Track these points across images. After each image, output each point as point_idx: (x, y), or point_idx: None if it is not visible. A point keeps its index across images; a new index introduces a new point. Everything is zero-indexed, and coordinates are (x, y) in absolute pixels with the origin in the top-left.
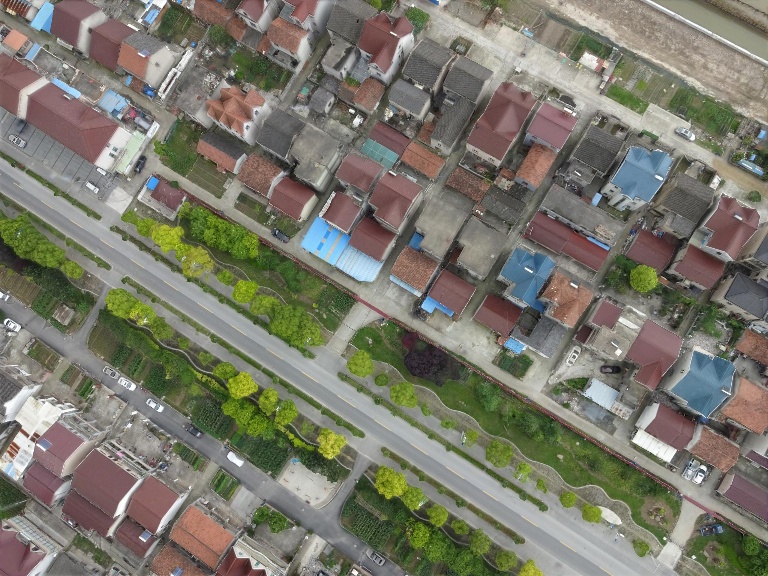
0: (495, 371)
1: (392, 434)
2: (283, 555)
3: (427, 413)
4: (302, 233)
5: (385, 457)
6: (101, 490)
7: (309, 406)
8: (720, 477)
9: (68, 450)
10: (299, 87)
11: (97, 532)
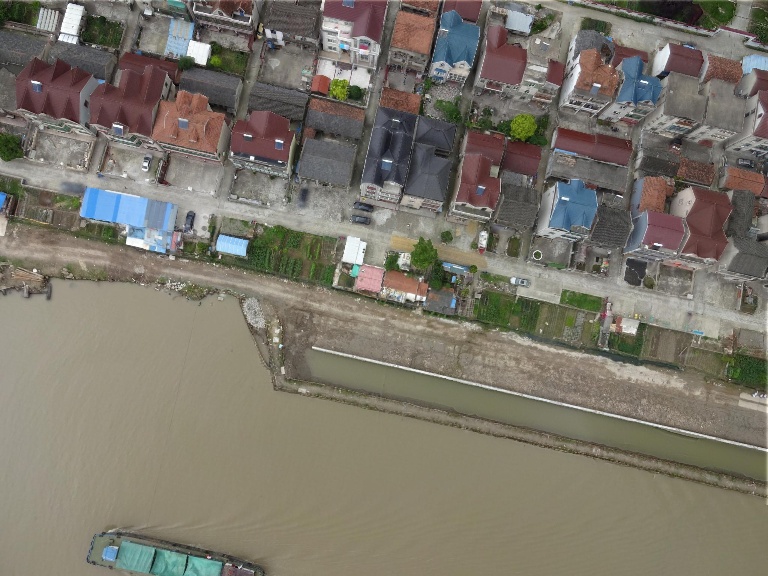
0: (606, 18)
1: None
2: None
3: None
4: None
5: None
6: None
7: None
8: None
9: None
10: None
11: None
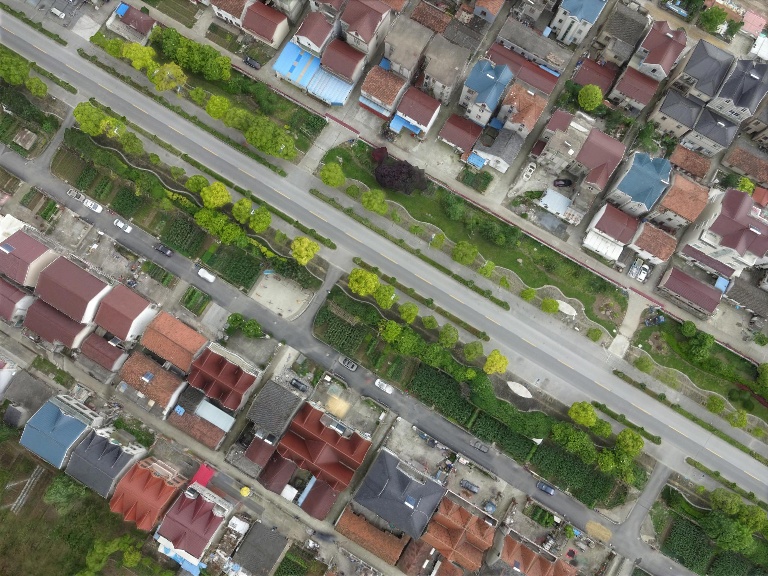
0: (459, 187)
1: (363, 245)
2: (255, 366)
3: (397, 218)
4: (273, 61)
5: (357, 265)
6: (69, 291)
7: (281, 221)
8: (660, 275)
9: (33, 255)
10: None
11: (60, 352)
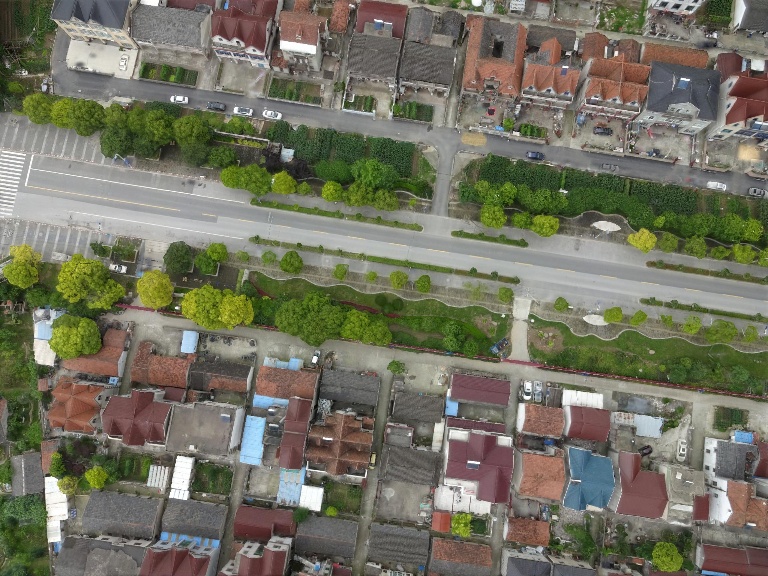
0: (742, 404)
1: None
2: None
3: None
4: None
5: None
6: None
7: None
8: None
9: None
10: None
11: None
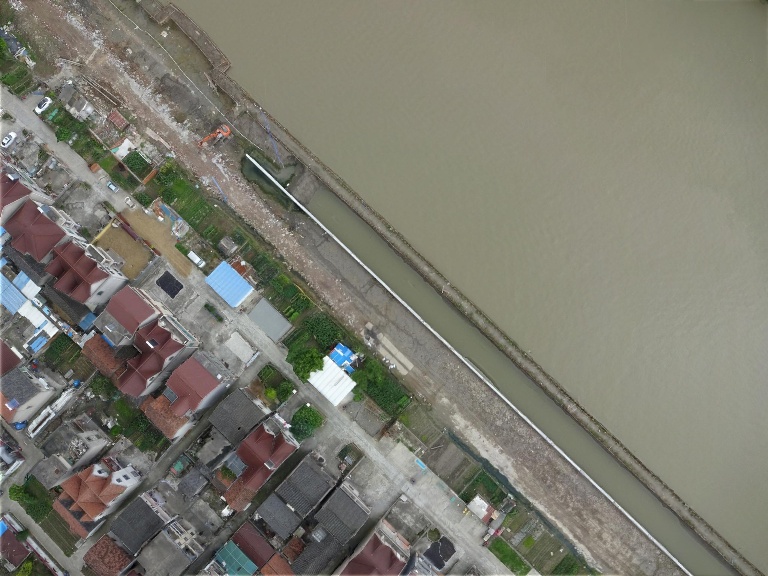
0: None
1: None
2: None
3: None
4: None
5: None
6: None
7: None
8: None
9: None
10: (176, 455)
11: None
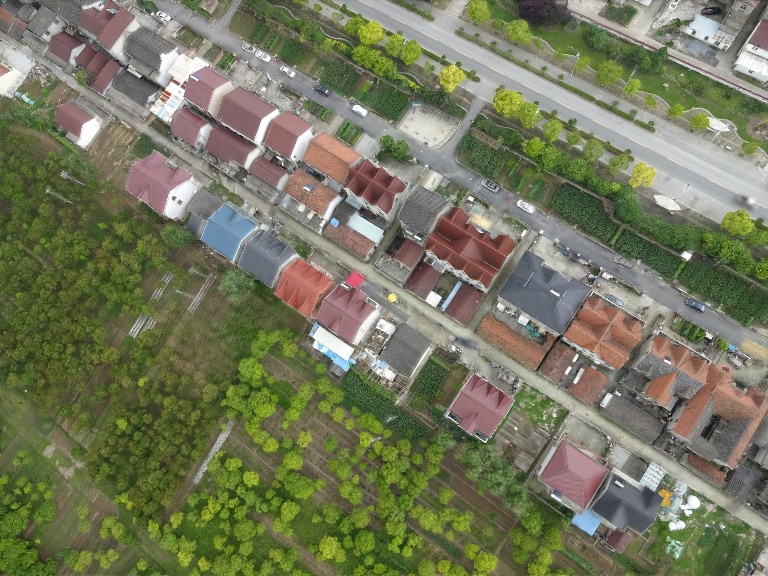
0: (601, 21)
1: (506, 78)
2: None
3: (541, 46)
4: None
5: None
6: (246, 110)
7: (429, 60)
8: None
9: (217, 84)
10: None
11: (232, 176)
